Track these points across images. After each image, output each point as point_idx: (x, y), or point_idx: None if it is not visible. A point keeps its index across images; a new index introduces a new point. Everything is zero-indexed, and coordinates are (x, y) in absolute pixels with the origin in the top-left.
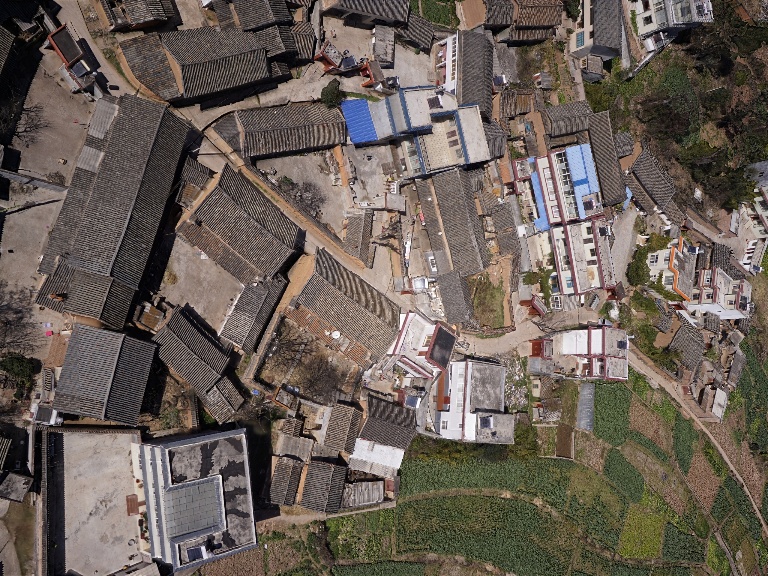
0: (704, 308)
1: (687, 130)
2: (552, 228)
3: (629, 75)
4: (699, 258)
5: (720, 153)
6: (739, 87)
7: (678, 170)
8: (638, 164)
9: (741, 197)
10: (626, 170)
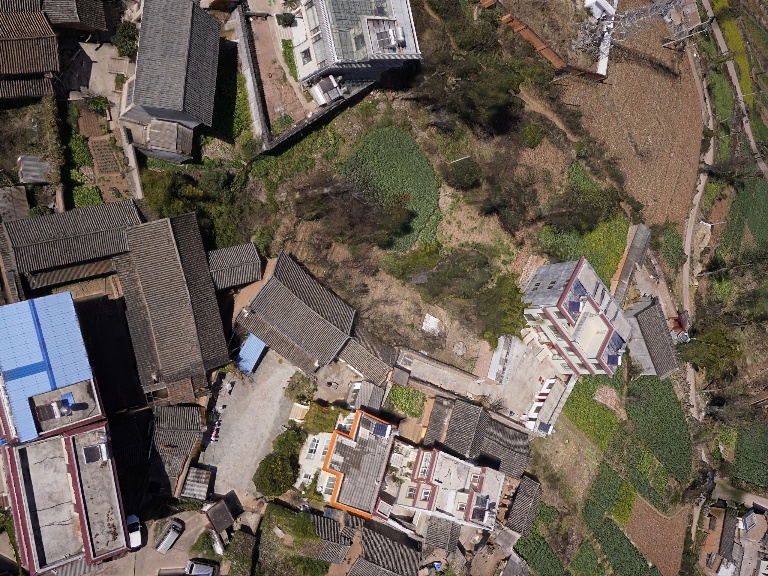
0: (424, 511)
1: (405, 226)
2: (4, 445)
3: (262, 147)
4: (428, 425)
5: (439, 268)
6: (534, 149)
7: (392, 288)
8: (261, 299)
9: (500, 328)
10: (244, 308)
